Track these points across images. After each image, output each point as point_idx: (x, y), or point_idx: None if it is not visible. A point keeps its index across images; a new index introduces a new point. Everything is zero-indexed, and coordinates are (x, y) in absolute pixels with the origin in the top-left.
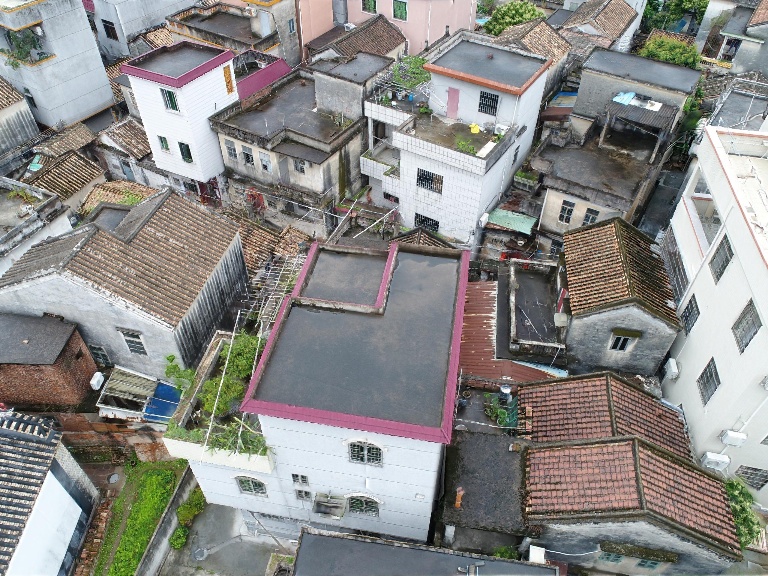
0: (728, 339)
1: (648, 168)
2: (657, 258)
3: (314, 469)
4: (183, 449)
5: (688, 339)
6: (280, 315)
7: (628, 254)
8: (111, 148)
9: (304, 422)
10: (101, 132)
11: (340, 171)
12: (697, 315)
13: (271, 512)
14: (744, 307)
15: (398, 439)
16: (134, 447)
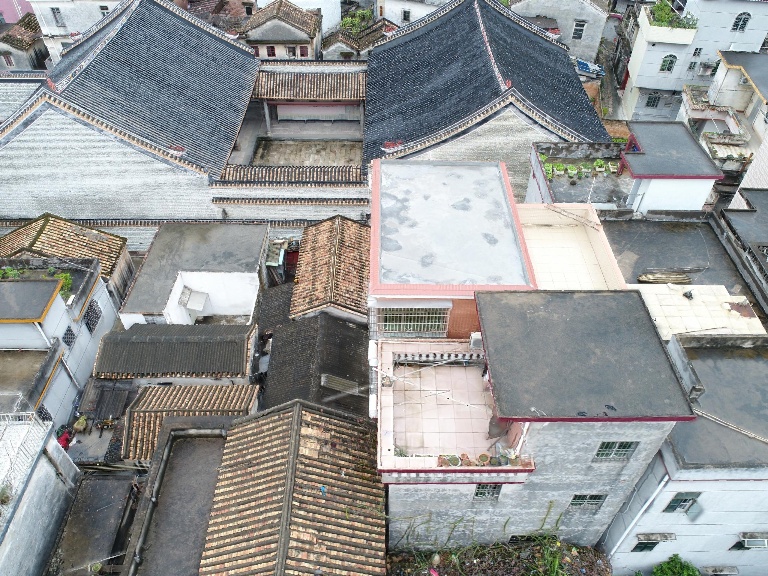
0: None
1: None
2: None
3: (709, 41)
4: (656, 33)
5: None
6: None
7: None
8: None
9: (723, 5)
10: None
11: None
12: None
13: (666, 87)
14: None
15: (761, 9)
16: None
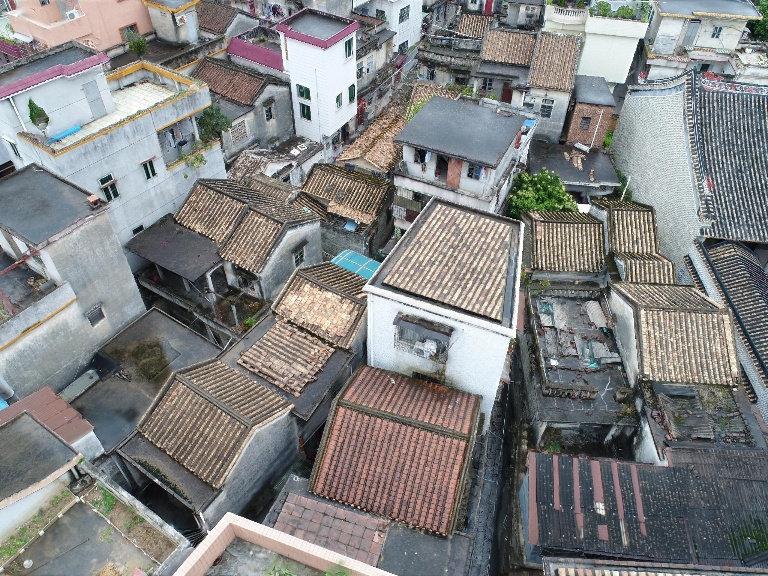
0: None
1: None
2: None
3: None
4: None
5: None
6: None
7: None
8: (275, 175)
9: None
10: (265, 167)
11: None
12: None
13: None
14: None
15: None
16: None
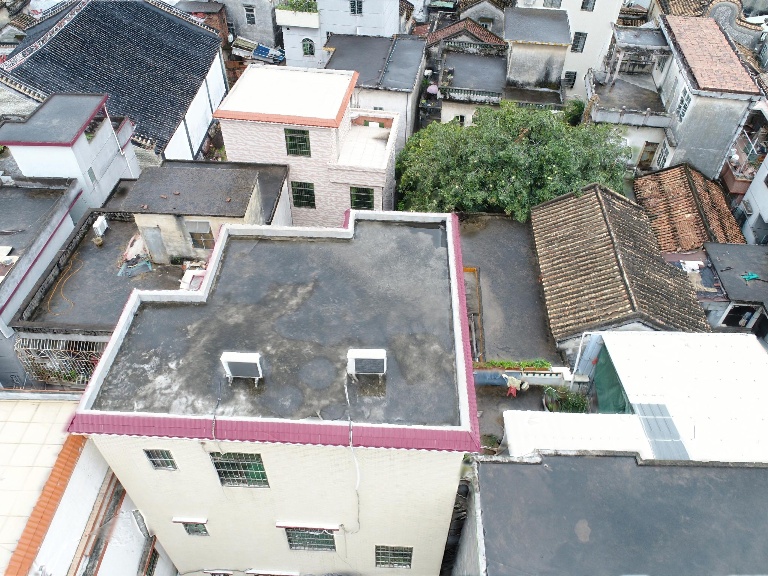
0: None
1: None
2: None
3: (336, 25)
4: (283, 17)
5: None
6: None
7: None
8: None
9: None
10: None
11: None
12: None
13: None
14: None
15: None
16: None
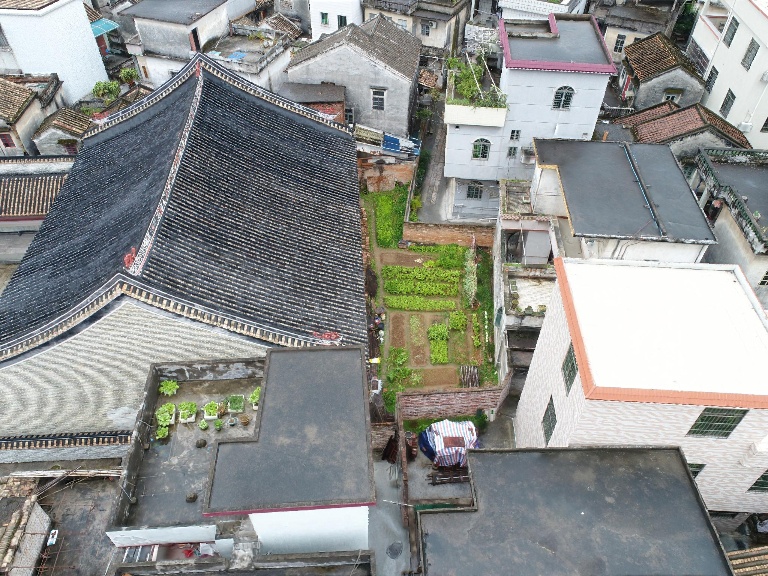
0: (739, 70)
1: (672, 11)
2: (686, 56)
3: (527, 122)
4: (455, 113)
5: (711, 93)
6: (506, 37)
7: (670, 48)
8: None
9: (535, 77)
10: (261, 22)
11: (454, 33)
12: (716, 75)
13: (484, 177)
14: (748, 46)
15: (585, 81)
16: (366, 181)
